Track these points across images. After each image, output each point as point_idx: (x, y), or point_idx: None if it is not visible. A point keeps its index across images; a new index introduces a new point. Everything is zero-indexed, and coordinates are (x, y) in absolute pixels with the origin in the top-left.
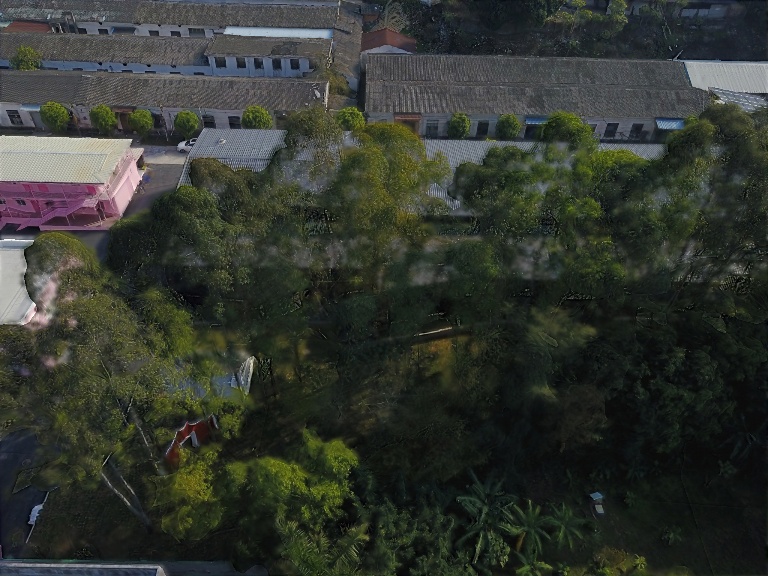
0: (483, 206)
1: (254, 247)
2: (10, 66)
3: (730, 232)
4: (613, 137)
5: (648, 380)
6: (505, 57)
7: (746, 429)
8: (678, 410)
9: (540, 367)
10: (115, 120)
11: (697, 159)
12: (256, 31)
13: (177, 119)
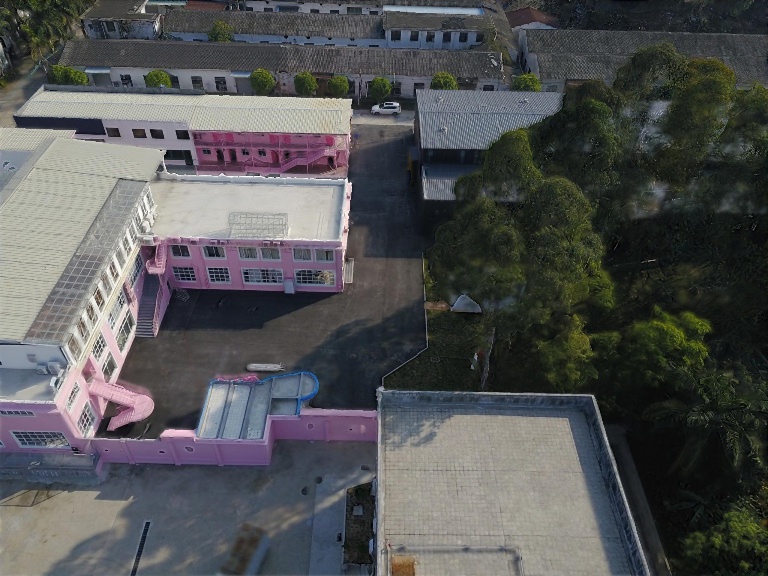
0: None
1: (623, 155)
2: (204, 39)
3: None
4: None
5: None
6: (650, 32)
7: None
8: None
9: None
10: (317, 85)
11: None
12: (412, 9)
13: (374, 84)
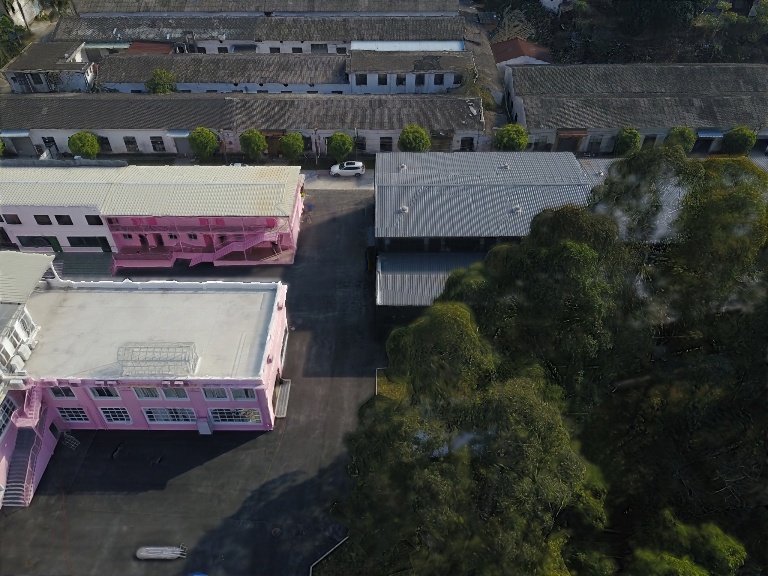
0: None
1: (616, 307)
2: (143, 90)
3: None
4: None
5: None
6: (656, 65)
7: None
8: None
9: None
10: (266, 144)
11: None
12: (383, 45)
13: (332, 142)
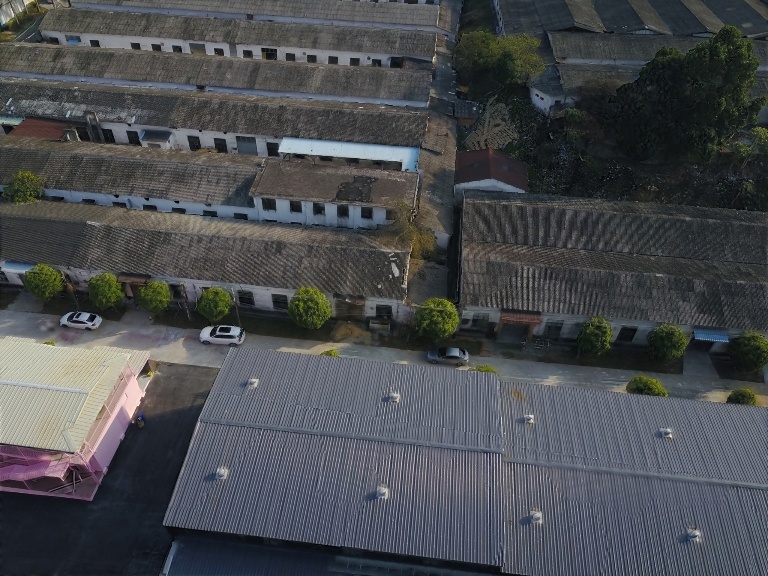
0: None
1: None
2: None
3: None
4: None
5: None
6: (656, 213)
7: None
8: None
9: None
10: (121, 294)
11: None
12: (320, 146)
13: (201, 302)
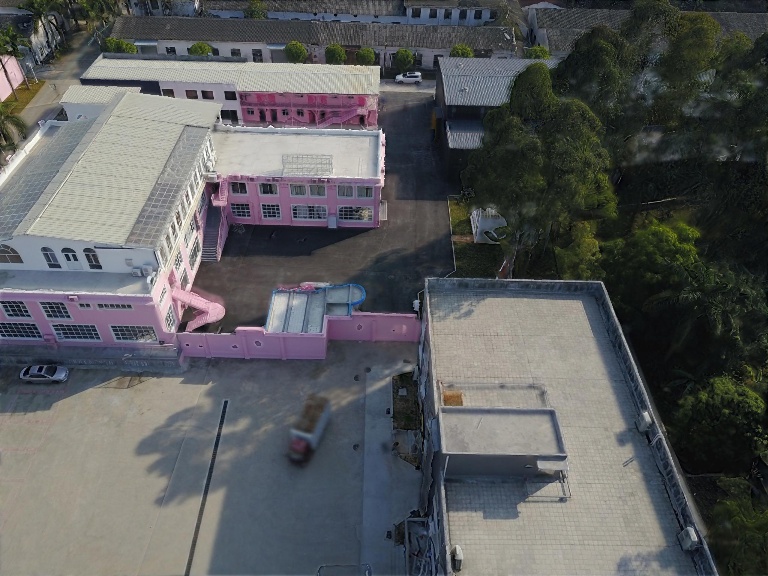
0: (767, 70)
1: None
2: (240, 16)
3: None
4: None
5: None
6: None
7: None
8: None
9: None
10: None
11: None
12: None
13: (398, 55)
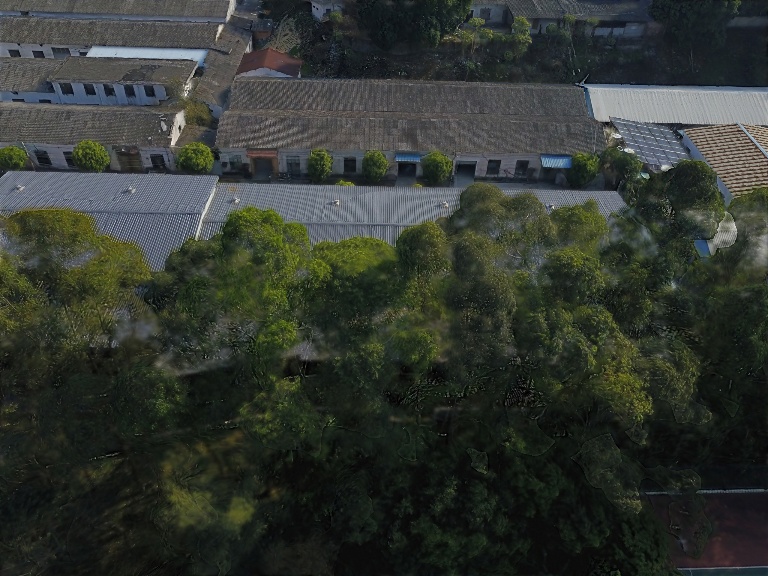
0: (161, 319)
1: None
2: None
3: (458, 362)
4: (497, 174)
5: (408, 521)
6: (388, 82)
7: (546, 570)
8: (445, 558)
9: (220, 533)
10: None
11: (416, 267)
12: (123, 51)
13: None
